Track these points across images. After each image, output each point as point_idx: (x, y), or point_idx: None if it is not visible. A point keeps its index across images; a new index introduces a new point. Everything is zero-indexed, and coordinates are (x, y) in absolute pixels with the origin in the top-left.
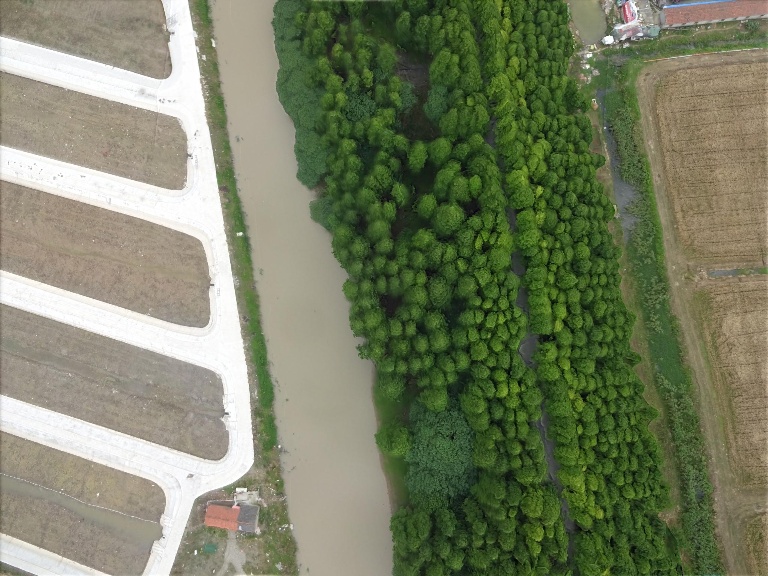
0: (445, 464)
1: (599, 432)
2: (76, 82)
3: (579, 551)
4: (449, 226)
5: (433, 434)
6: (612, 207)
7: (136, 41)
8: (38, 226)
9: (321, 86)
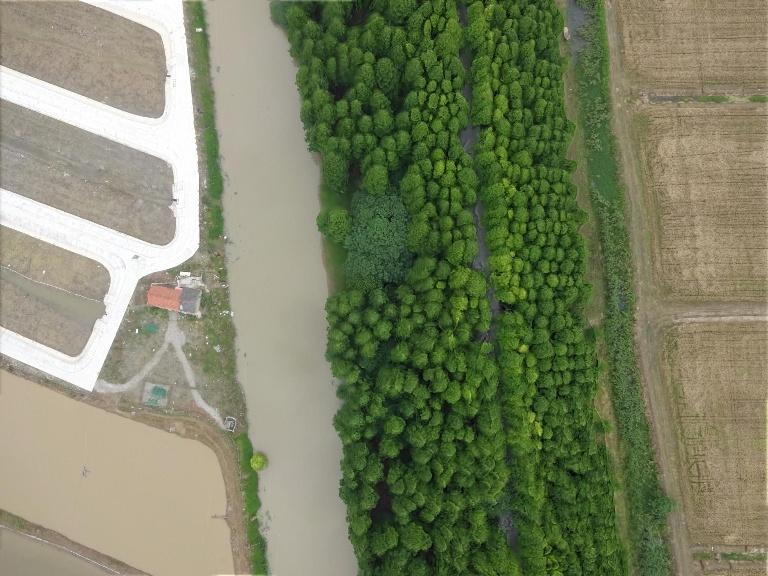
0: (381, 247)
1: (529, 221)
2: None
3: (501, 326)
4: (400, 13)
5: (372, 216)
6: (561, 18)
7: None
8: None
9: None
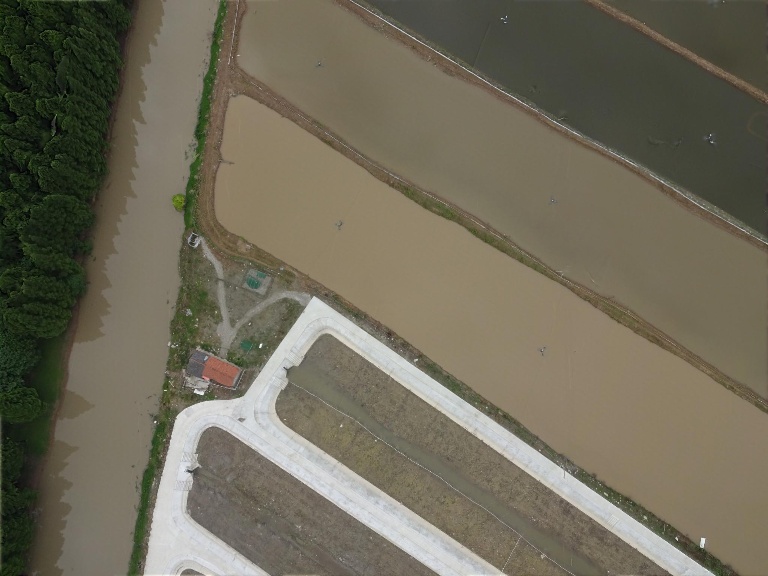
0: None
1: None
2: None
3: None
4: None
5: None
6: None
7: None
8: None
9: None
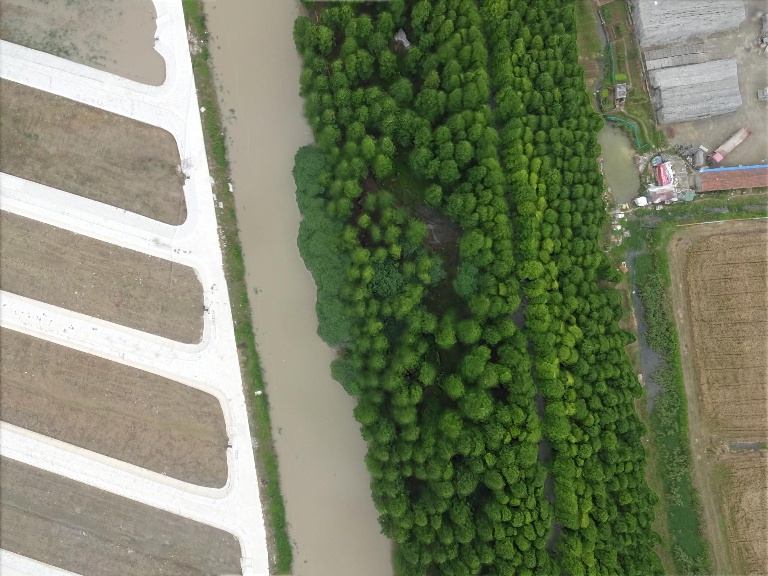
0: None
1: None
2: (86, 227)
3: None
4: (477, 419)
5: None
6: (640, 389)
7: (149, 182)
8: (48, 378)
9: (346, 254)
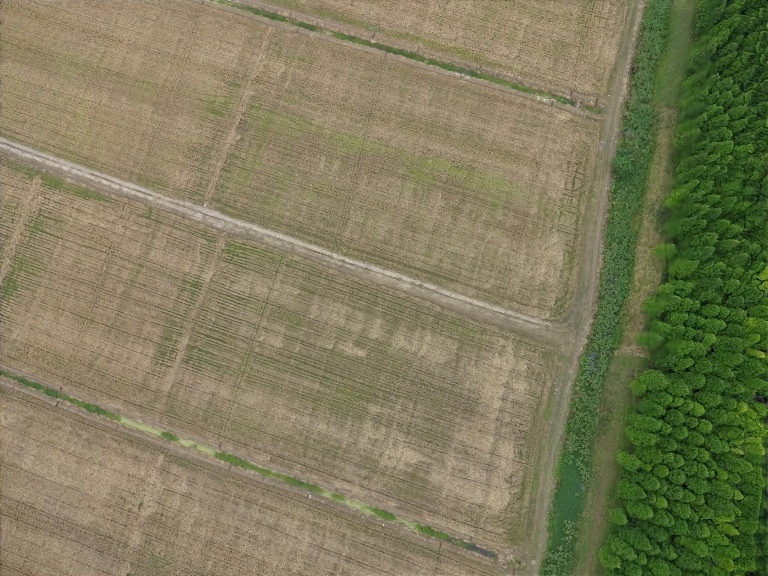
0: None
1: (711, 479)
2: None
3: None
4: None
5: None
6: None
7: None
8: None
9: None
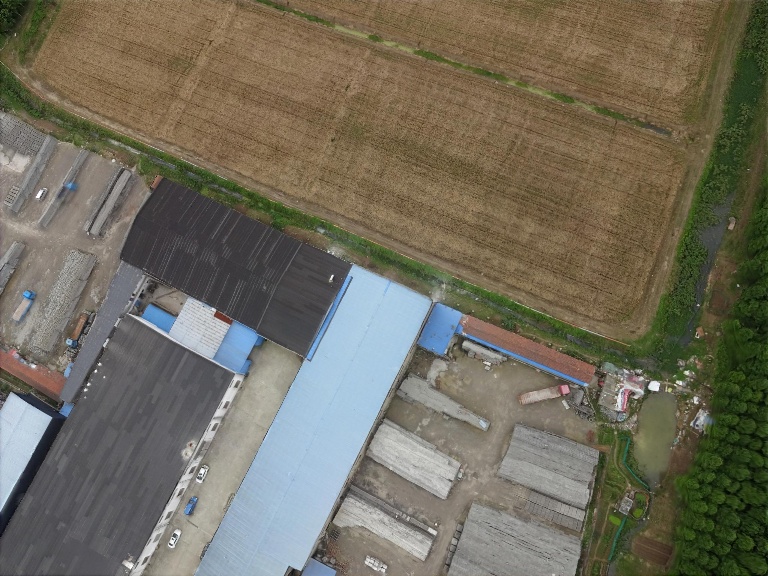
0: None
1: None
2: None
3: None
4: None
5: None
6: (767, 215)
7: None
8: None
9: None
